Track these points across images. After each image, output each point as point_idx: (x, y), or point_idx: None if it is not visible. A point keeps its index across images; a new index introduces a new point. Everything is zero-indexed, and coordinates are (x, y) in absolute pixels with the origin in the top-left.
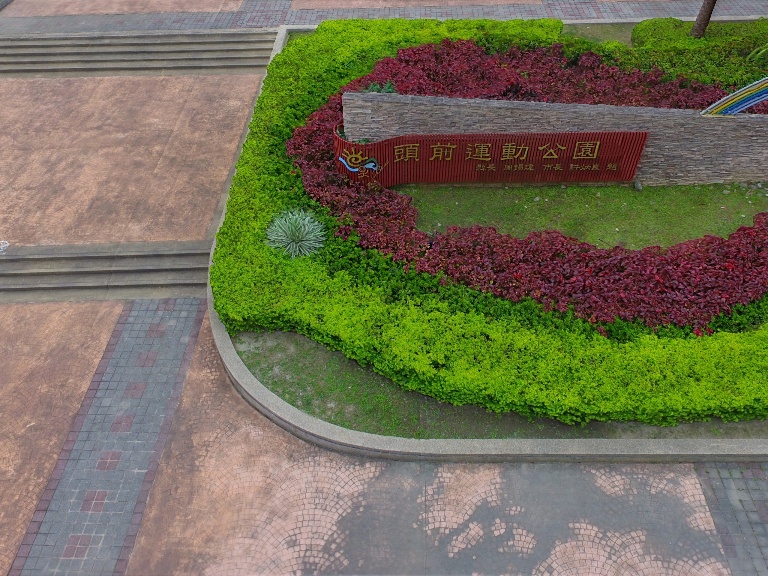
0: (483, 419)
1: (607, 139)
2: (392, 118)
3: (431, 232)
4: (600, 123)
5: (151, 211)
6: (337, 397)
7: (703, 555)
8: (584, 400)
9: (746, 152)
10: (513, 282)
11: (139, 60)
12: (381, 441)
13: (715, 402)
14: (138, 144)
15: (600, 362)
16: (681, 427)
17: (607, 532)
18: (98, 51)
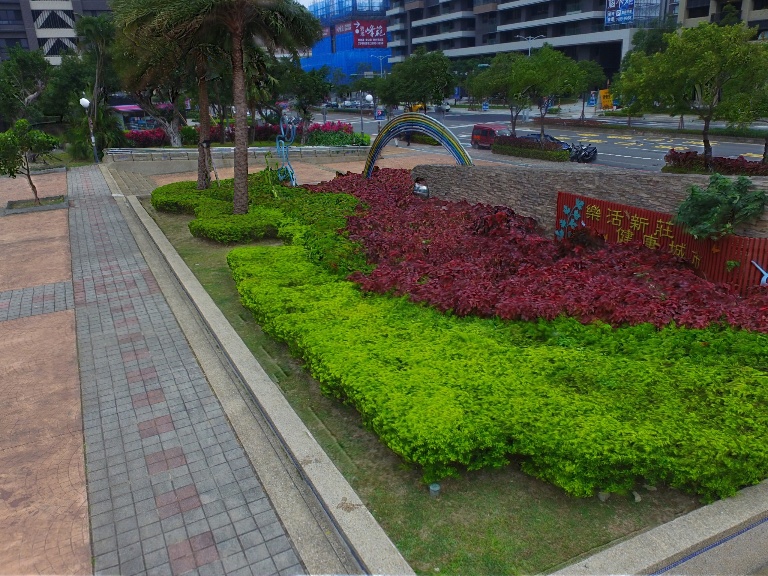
0: None
1: None
2: None
3: None
4: None
5: None
6: None
7: None
8: None
9: None
10: None
11: None
12: None
13: None
14: None
15: None
16: None
17: None
18: None
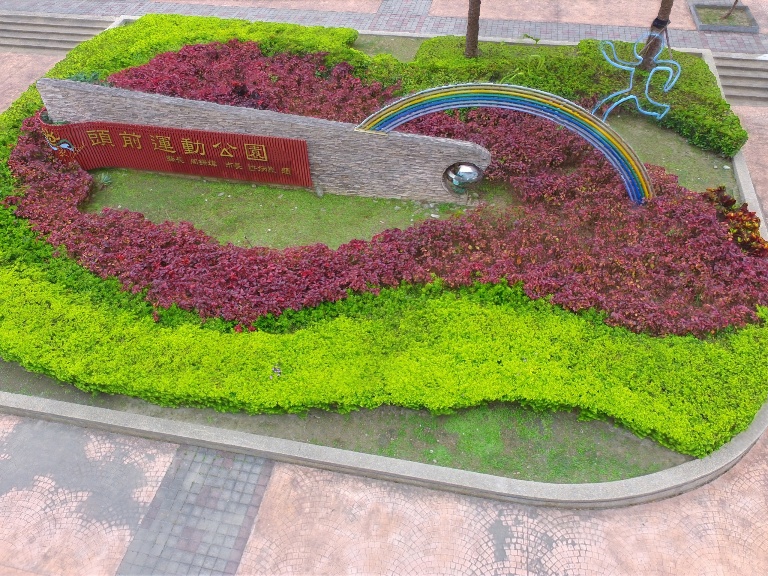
0: (26, 377)
1: (271, 144)
2: (82, 105)
3: None
4: (263, 128)
5: None
6: None
7: (121, 521)
8: (87, 370)
9: (410, 170)
10: (113, 262)
11: None
12: None
13: (194, 390)
14: None
15: (128, 341)
16: (183, 410)
17: (60, 488)
18: None
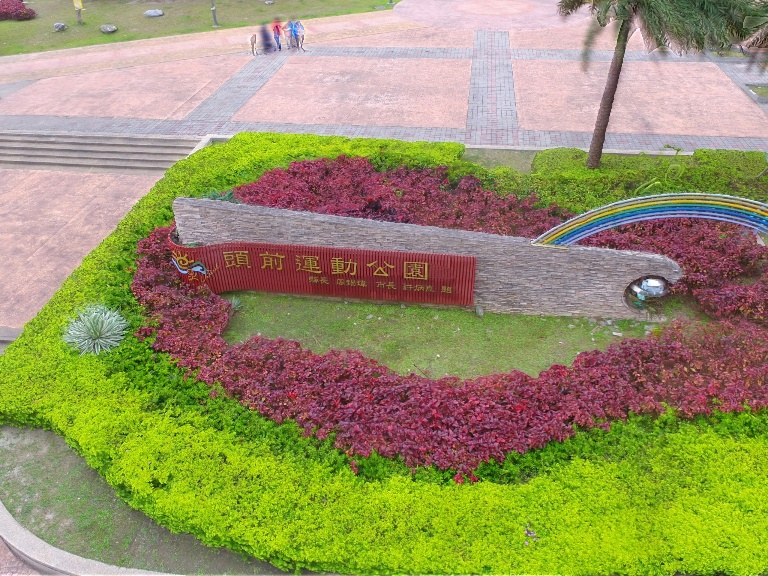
0: (199, 552)
1: (435, 261)
2: (221, 224)
3: (243, 341)
4: (427, 244)
5: (1, 296)
6: (60, 508)
7: None
8: (293, 544)
9: (588, 286)
10: (285, 401)
11: (74, 157)
12: (78, 564)
13: (437, 564)
14: (29, 232)
15: (332, 501)
16: None
17: None
18: (42, 147)
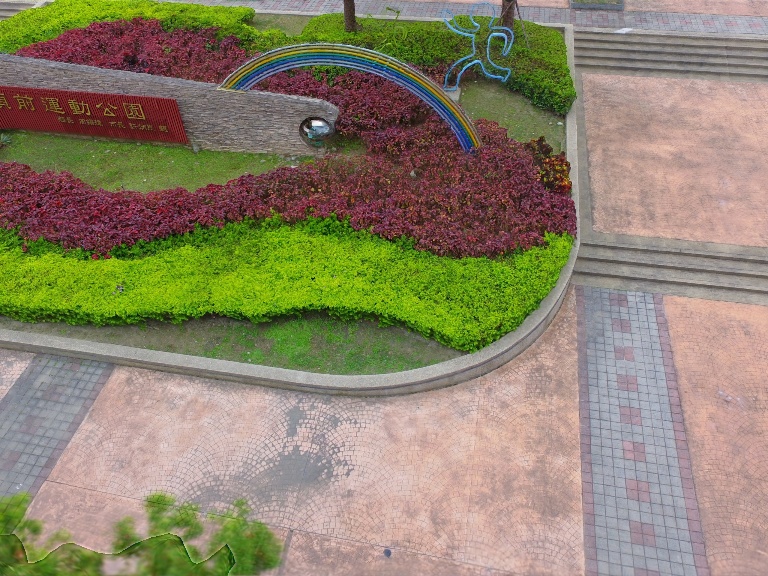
0: None
1: (146, 103)
2: None
3: None
4: (138, 88)
5: None
6: None
7: None
8: None
9: (270, 126)
10: None
11: None
12: None
13: (46, 304)
14: None
15: None
16: (41, 325)
17: None
18: None
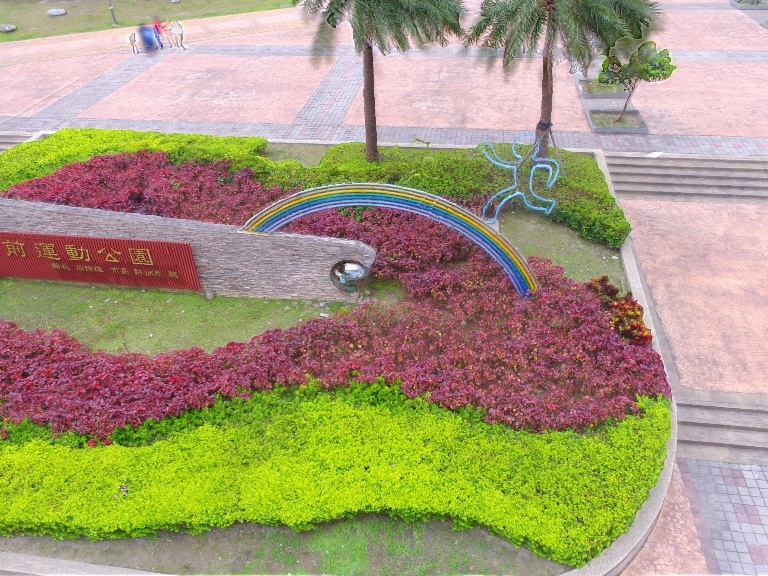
0: None
1: (155, 248)
2: None
3: None
4: (147, 232)
5: None
6: None
7: None
8: None
9: (296, 270)
10: None
11: None
12: None
13: (27, 515)
14: None
15: None
16: (19, 540)
17: None
18: None
